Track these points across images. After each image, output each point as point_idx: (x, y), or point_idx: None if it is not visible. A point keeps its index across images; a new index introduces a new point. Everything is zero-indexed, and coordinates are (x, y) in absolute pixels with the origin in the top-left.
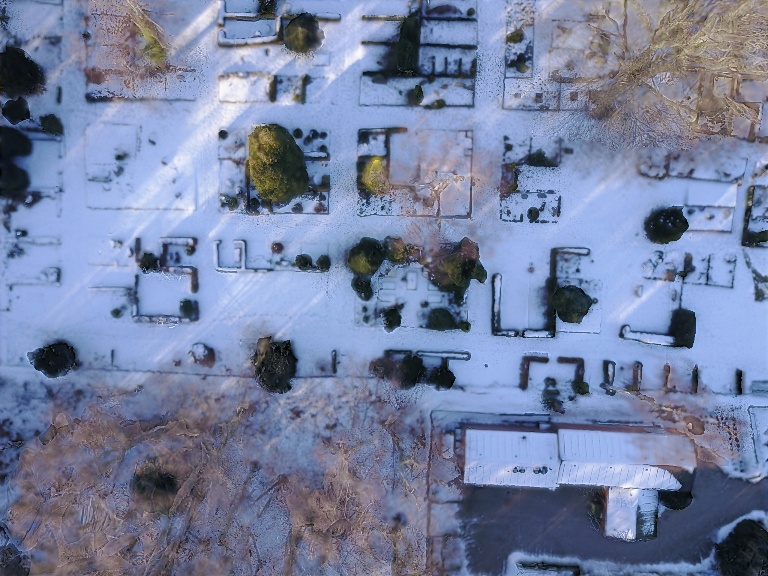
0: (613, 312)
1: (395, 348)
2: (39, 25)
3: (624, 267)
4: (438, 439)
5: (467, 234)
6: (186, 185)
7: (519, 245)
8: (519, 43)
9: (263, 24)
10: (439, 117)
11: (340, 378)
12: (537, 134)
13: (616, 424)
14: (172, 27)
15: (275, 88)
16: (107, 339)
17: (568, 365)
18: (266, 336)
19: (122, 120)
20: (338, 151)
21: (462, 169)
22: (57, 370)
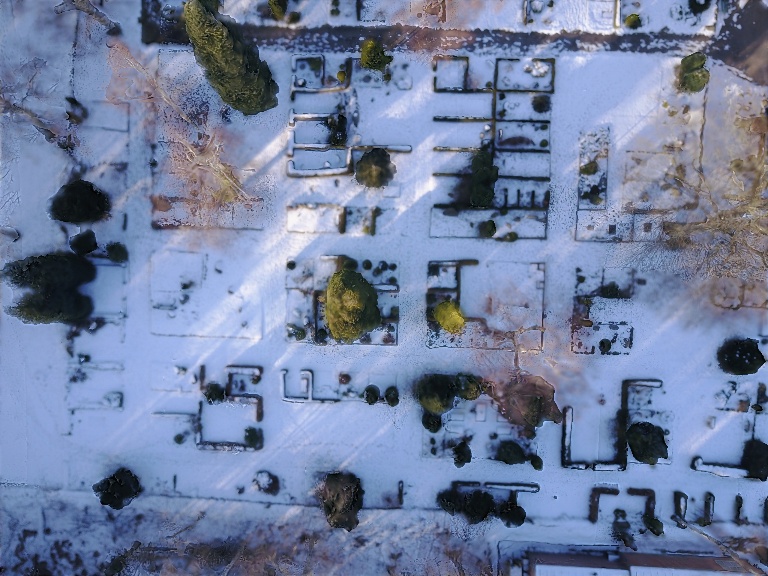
0: (684, 443)
1: (463, 479)
2: (105, 152)
3: (696, 398)
4: (505, 570)
5: (538, 366)
6: (252, 314)
7: (590, 377)
8: (593, 175)
9: (332, 154)
10: (511, 249)
11: (407, 510)
12: (610, 265)
13: (686, 554)
14: (240, 156)
15: (344, 220)
16: (169, 464)
17: (638, 497)
18: (331, 465)
19: (188, 248)
20: (407, 282)
21: (534, 302)
22: (122, 501)
